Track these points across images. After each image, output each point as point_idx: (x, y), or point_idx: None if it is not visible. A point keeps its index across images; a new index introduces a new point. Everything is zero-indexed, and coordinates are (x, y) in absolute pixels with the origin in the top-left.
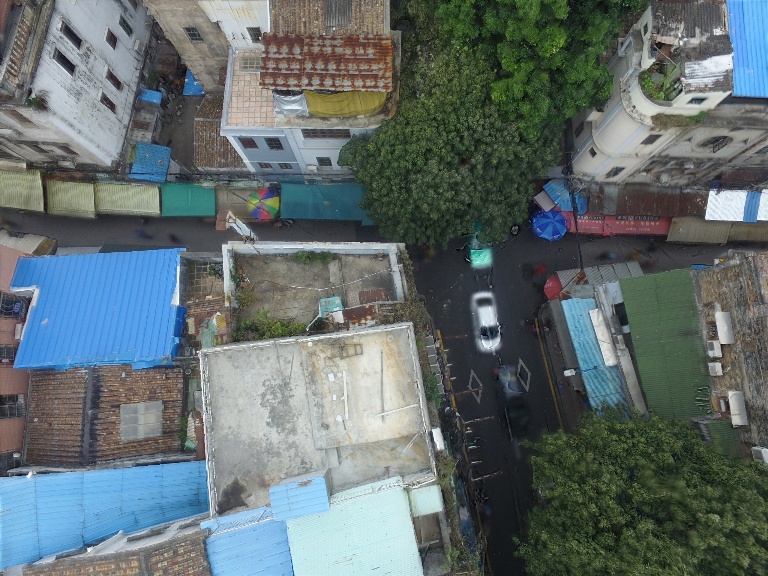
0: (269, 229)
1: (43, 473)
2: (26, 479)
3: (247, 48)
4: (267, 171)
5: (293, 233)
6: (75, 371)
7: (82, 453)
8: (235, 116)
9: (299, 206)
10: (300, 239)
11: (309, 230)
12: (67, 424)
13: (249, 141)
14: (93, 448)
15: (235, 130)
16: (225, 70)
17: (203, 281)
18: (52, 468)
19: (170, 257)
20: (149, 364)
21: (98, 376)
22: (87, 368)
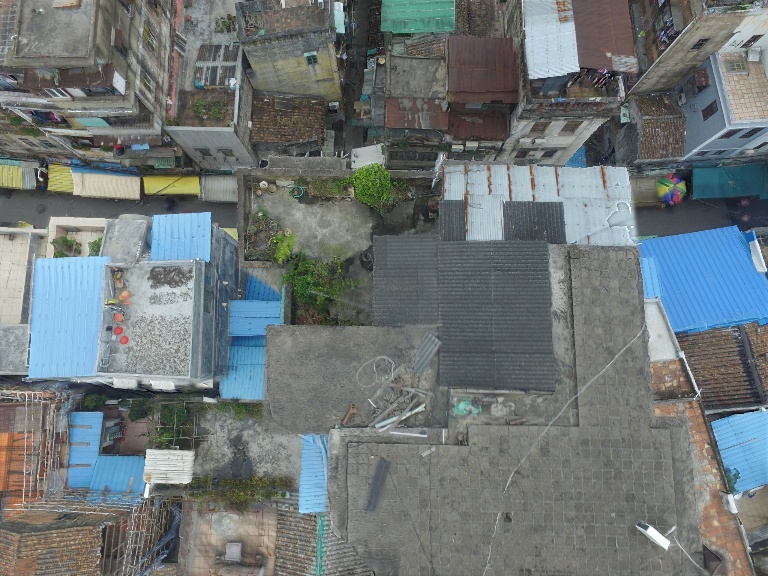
0: (651, 211)
1: (712, 415)
2: (761, 413)
3: (728, 53)
4: (694, 158)
5: (673, 213)
6: (715, 331)
7: (756, 394)
8: (737, 112)
9: (707, 187)
10: (680, 217)
11: (686, 209)
12: (719, 374)
13: (731, 132)
14: (763, 389)
15: (743, 123)
16: (700, 73)
17: (761, 251)
18: (729, 409)
19: (729, 234)
20: (767, 320)
21: (746, 332)
22: (735, 327)
